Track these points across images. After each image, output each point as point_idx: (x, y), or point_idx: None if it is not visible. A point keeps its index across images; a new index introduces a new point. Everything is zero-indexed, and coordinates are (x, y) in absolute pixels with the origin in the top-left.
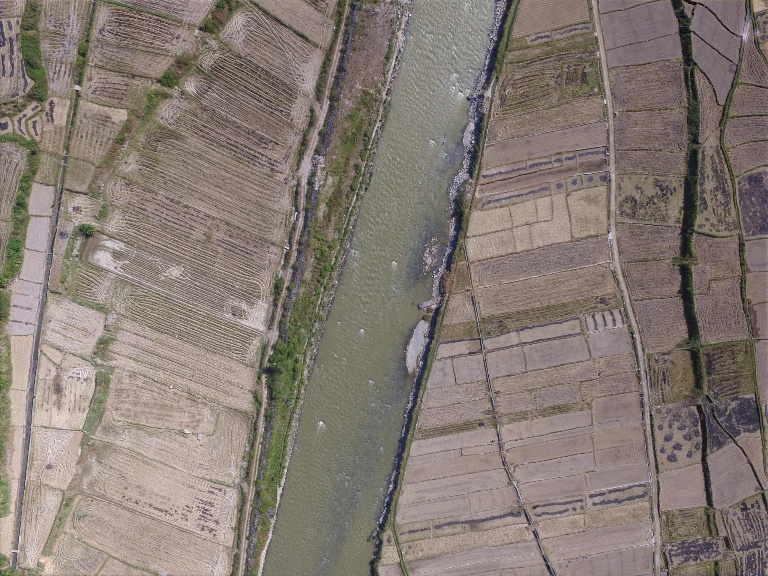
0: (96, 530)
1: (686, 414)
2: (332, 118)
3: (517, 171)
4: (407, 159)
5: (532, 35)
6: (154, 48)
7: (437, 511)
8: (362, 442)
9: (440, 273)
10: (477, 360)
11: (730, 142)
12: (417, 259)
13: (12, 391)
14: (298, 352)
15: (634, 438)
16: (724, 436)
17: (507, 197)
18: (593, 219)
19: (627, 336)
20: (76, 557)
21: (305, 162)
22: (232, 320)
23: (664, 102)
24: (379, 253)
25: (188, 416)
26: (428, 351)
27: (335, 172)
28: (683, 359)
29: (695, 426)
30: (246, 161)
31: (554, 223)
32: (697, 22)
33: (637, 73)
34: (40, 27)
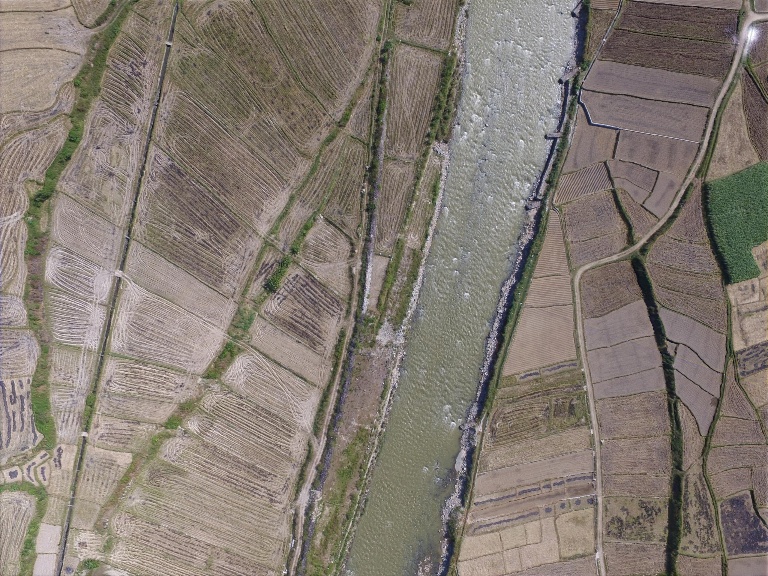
0: None
1: None
2: (329, 456)
3: (507, 498)
4: (401, 485)
5: (521, 373)
6: (159, 396)
7: None
8: None
9: None
10: None
11: (712, 470)
12: None
13: None
14: None
15: None
16: None
17: (497, 522)
18: (581, 539)
19: None
20: None
21: (303, 493)
22: None
23: (649, 430)
24: (374, 573)
25: None
26: None
27: (332, 503)
28: None
29: None
30: (246, 493)
31: (543, 545)
32: (680, 360)
33: (622, 404)
34: (50, 380)
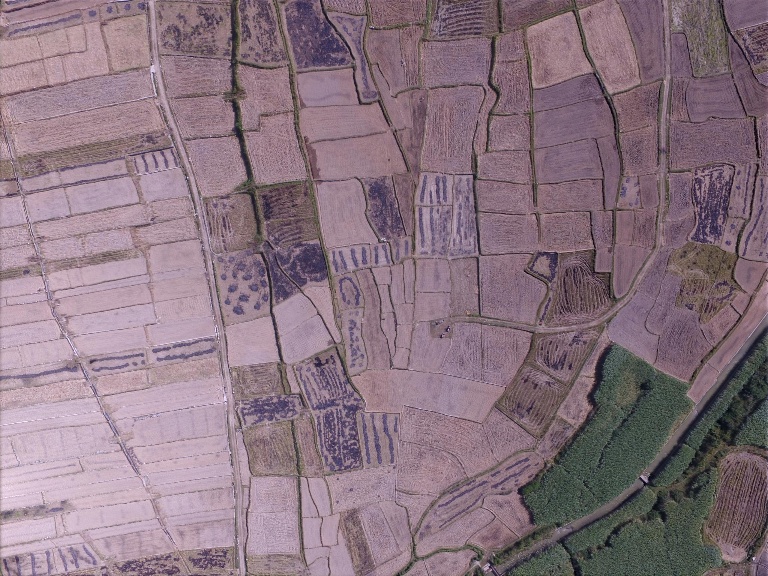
0: None
1: (251, 263)
2: None
3: None
4: None
5: None
6: None
7: None
8: None
9: None
10: (16, 202)
11: None
12: None
13: None
14: None
15: (198, 289)
16: (290, 285)
17: (35, 26)
18: (134, 51)
19: (182, 179)
20: None
21: None
22: None
23: None
24: None
25: None
26: None
27: None
28: (244, 203)
29: (262, 276)
30: None
31: (89, 54)
32: None
33: None
34: None
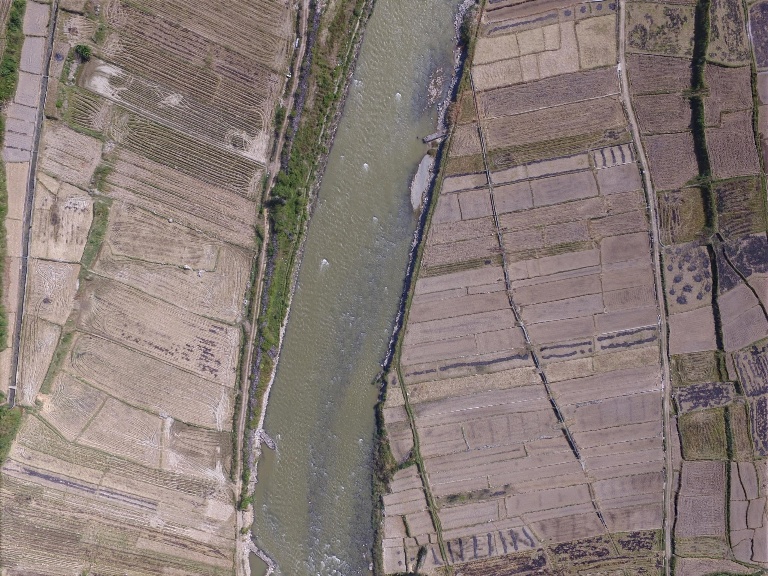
0: (95, 369)
1: (696, 254)
2: None
3: None
4: None
5: None
6: None
7: (443, 352)
8: (366, 281)
9: (445, 105)
10: (483, 195)
11: None
12: (422, 91)
13: (8, 220)
14: (300, 185)
15: (643, 279)
16: (735, 276)
17: (514, 24)
18: (602, 49)
19: (636, 173)
20: (75, 396)
21: None
22: (233, 151)
23: None
24: (383, 84)
25: (188, 251)
26: (433, 185)
27: None
28: (693, 197)
29: (705, 267)
30: None
31: (562, 52)
32: None
33: None
34: None
